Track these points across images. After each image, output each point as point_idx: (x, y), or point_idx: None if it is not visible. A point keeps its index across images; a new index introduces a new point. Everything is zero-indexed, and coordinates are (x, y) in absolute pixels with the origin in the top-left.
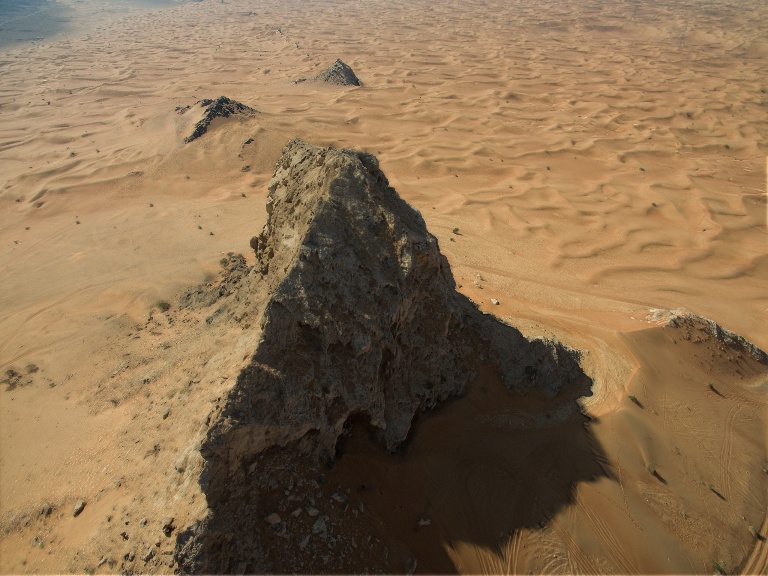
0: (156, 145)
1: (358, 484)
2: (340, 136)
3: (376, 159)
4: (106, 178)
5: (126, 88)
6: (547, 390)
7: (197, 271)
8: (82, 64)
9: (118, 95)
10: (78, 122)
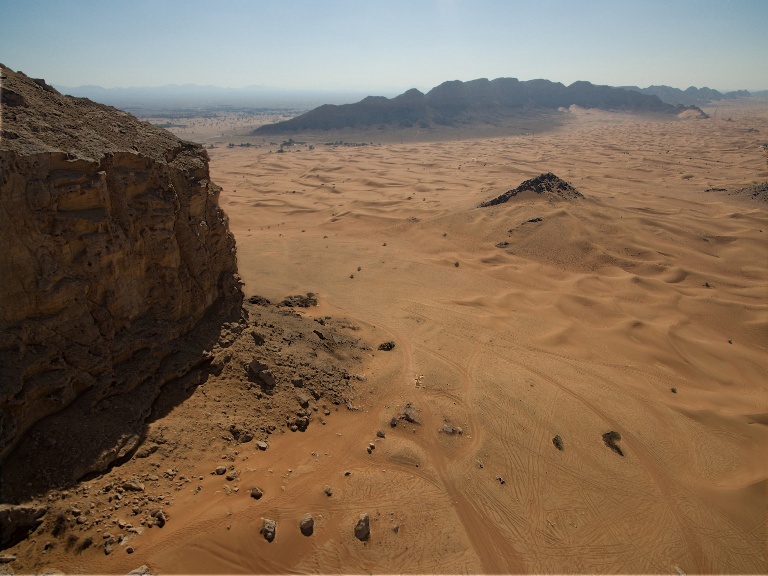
0: (458, 203)
1: None
2: (667, 248)
3: None
4: (393, 216)
5: (527, 168)
6: None
7: (273, 295)
8: (524, 150)
9: (515, 172)
10: (453, 181)
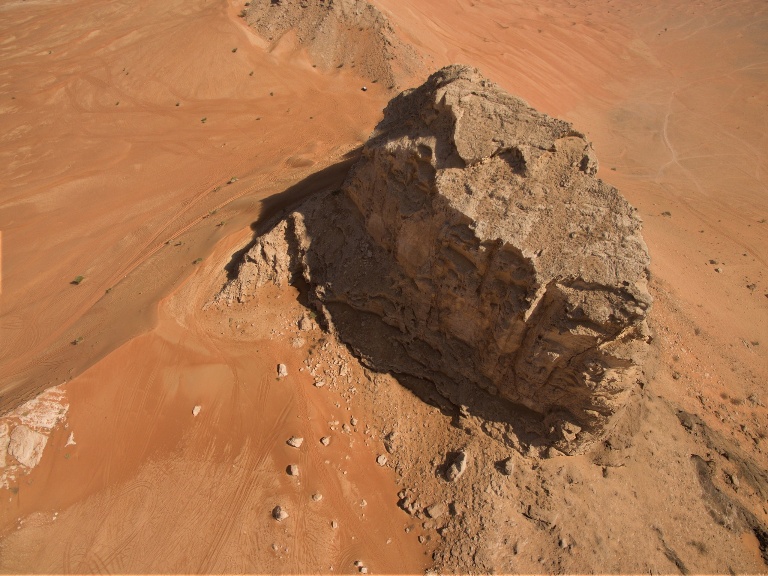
0: None
1: None
2: None
3: (437, 94)
4: None
5: None
6: None
7: None
8: None
9: None
10: None
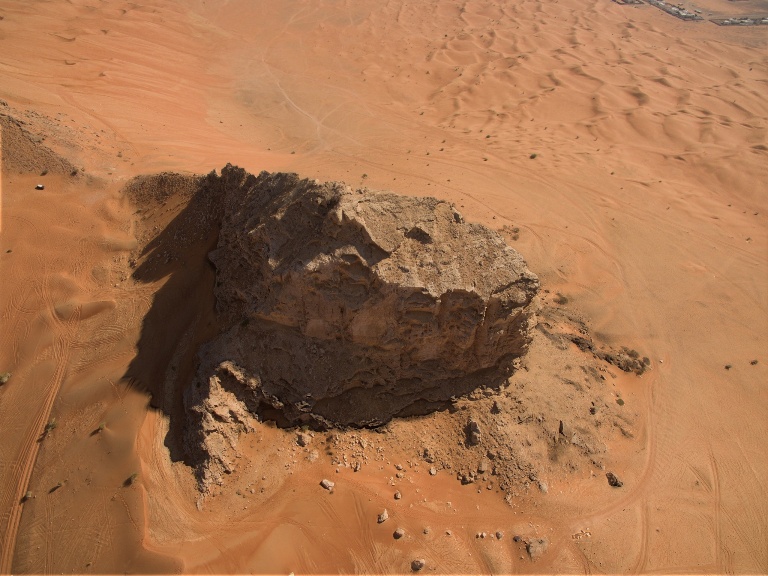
0: None
1: (209, 237)
2: None
3: (336, 215)
4: None
5: None
6: (188, 389)
7: (621, 331)
8: None
9: None
10: None
